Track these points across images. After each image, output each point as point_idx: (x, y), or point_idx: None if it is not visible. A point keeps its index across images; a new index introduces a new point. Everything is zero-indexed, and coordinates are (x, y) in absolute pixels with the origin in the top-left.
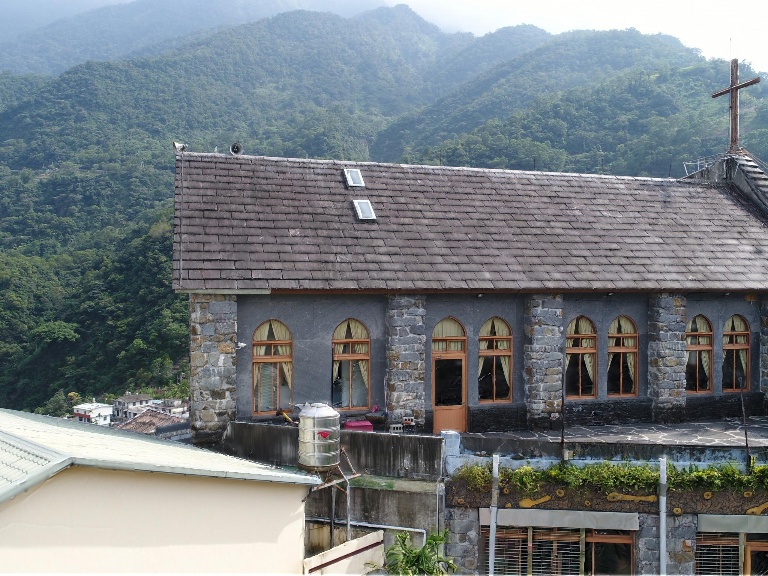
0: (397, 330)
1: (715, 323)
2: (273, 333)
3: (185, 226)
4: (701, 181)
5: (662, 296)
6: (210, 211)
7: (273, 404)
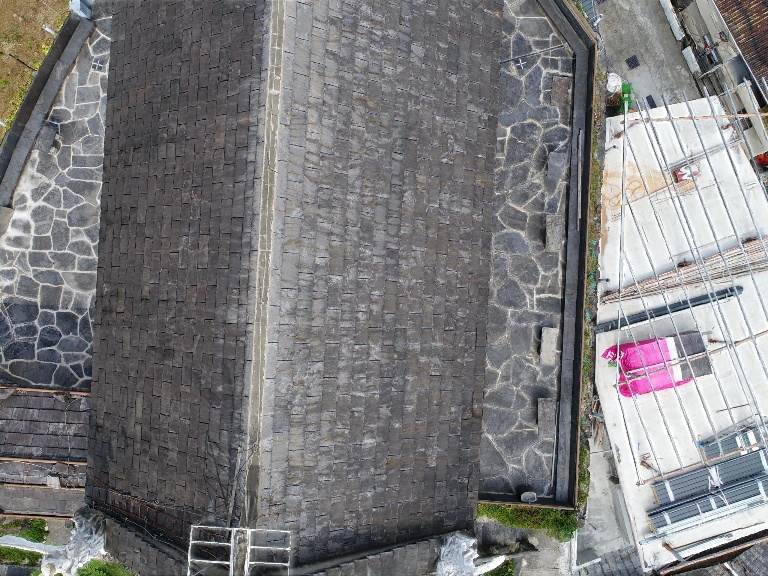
0: None
1: None
2: None
3: None
4: None
5: None
6: None
7: None
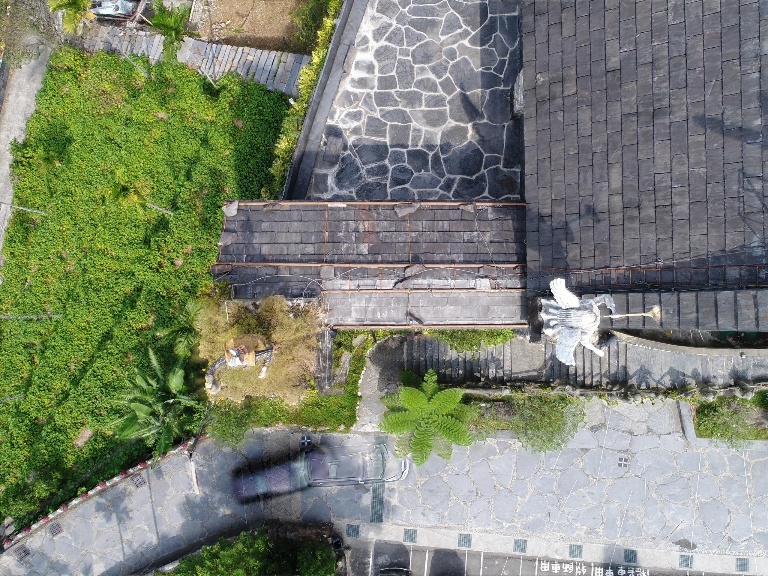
0: None
1: None
2: None
3: None
4: None
5: None
6: None
7: None
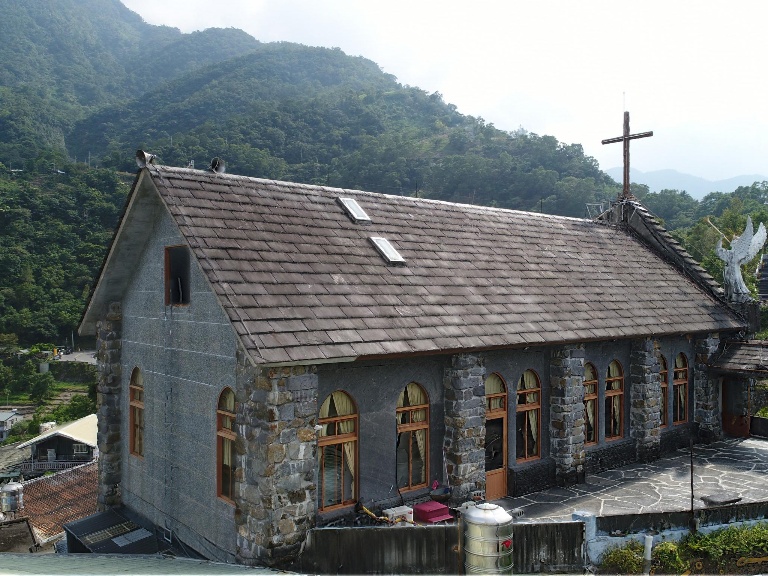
0: (463, 393)
1: (669, 362)
2: (334, 407)
3: (218, 271)
4: (608, 222)
5: (647, 340)
6: (234, 250)
7: (337, 496)
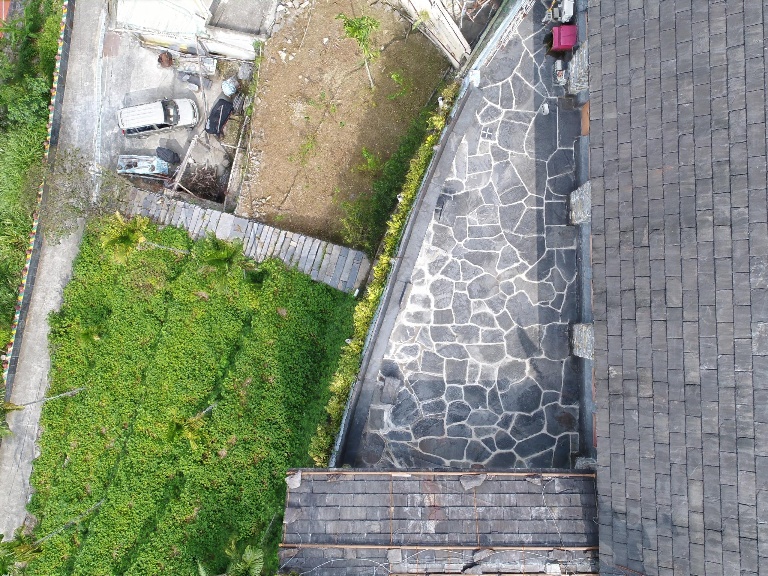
0: None
1: None
2: None
3: None
4: None
5: None
6: None
7: None
